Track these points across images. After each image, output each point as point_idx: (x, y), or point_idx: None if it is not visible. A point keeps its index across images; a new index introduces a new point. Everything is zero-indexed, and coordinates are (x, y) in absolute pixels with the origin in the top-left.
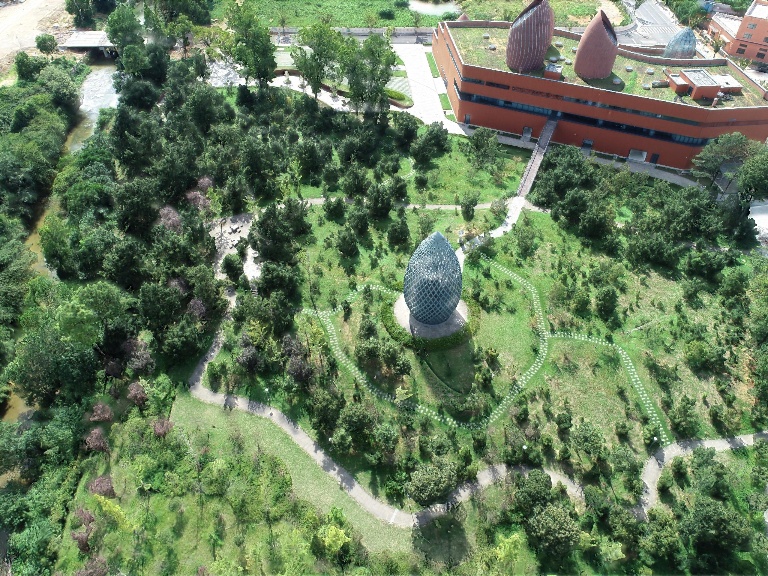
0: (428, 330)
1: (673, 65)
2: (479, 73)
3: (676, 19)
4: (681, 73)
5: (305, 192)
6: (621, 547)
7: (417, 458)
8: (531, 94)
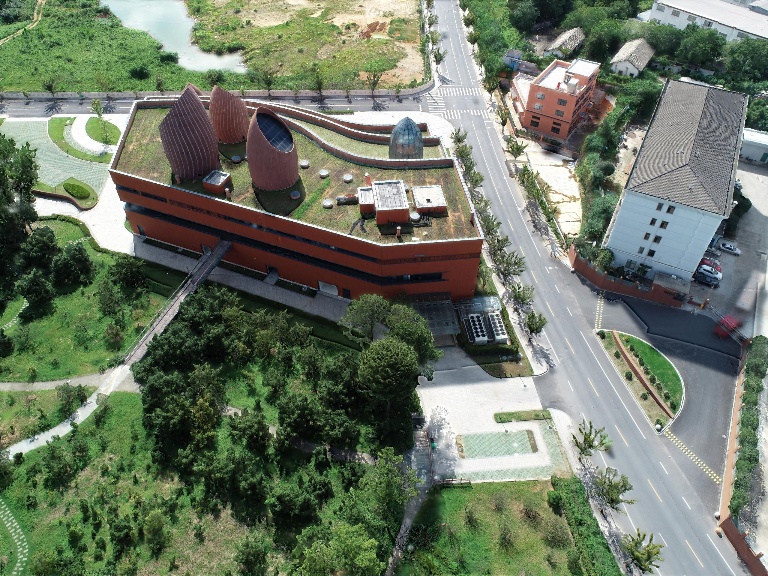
0: None
1: (385, 167)
2: (129, 181)
3: (484, 77)
4: None
5: None
6: None
7: None
8: (191, 210)
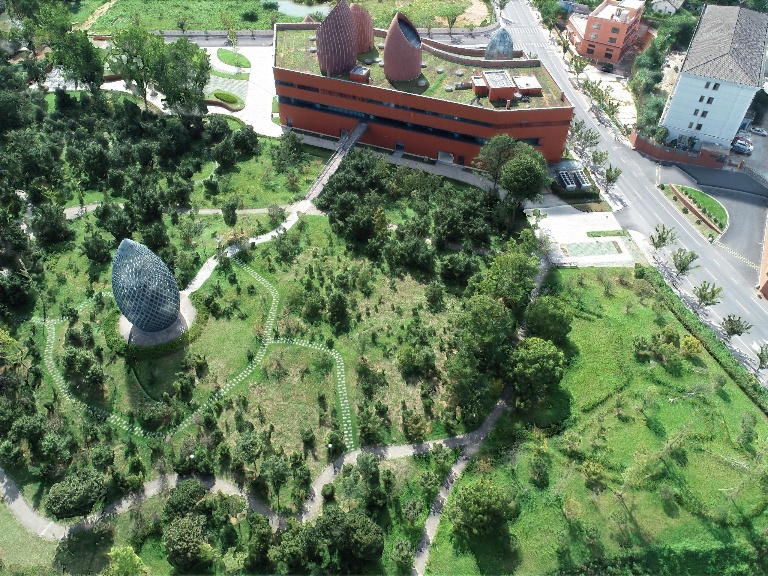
0: (146, 338)
1: (486, 66)
2: (289, 76)
3: (541, 19)
4: (483, 75)
5: (89, 198)
6: (258, 557)
7: (91, 469)
8: (339, 97)
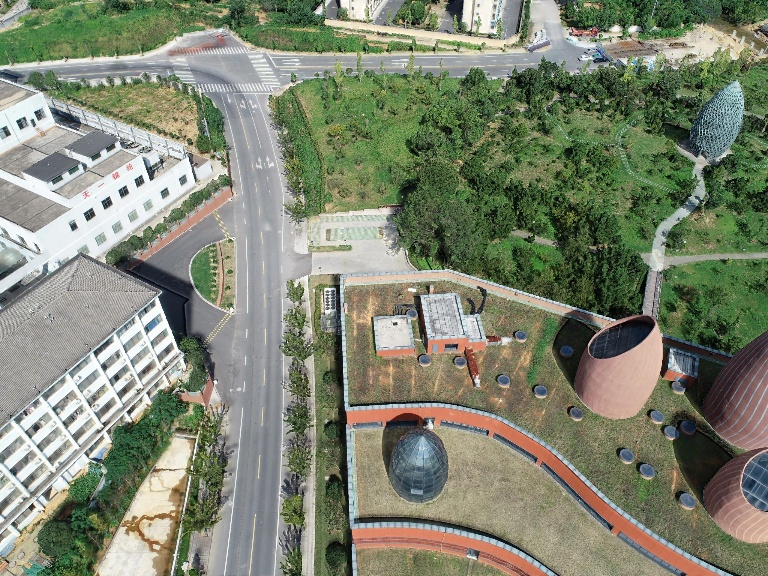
0: None
1: None
2: None
3: None
4: None
5: None
6: None
7: None
8: None
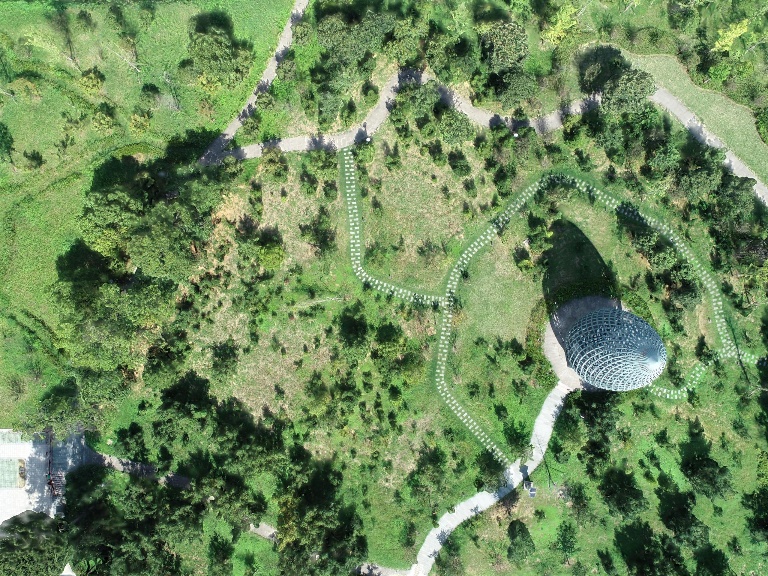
0: None
1: None
2: None
3: None
4: None
5: None
6: None
7: (622, 148)
8: None
